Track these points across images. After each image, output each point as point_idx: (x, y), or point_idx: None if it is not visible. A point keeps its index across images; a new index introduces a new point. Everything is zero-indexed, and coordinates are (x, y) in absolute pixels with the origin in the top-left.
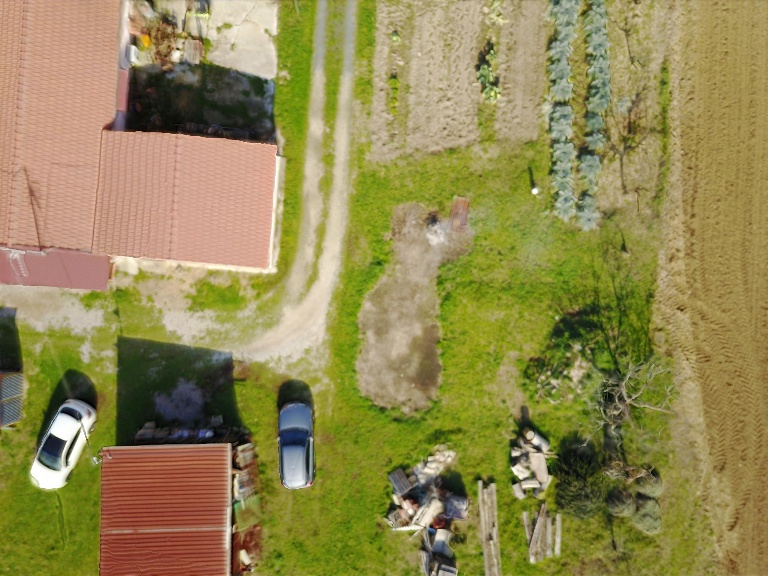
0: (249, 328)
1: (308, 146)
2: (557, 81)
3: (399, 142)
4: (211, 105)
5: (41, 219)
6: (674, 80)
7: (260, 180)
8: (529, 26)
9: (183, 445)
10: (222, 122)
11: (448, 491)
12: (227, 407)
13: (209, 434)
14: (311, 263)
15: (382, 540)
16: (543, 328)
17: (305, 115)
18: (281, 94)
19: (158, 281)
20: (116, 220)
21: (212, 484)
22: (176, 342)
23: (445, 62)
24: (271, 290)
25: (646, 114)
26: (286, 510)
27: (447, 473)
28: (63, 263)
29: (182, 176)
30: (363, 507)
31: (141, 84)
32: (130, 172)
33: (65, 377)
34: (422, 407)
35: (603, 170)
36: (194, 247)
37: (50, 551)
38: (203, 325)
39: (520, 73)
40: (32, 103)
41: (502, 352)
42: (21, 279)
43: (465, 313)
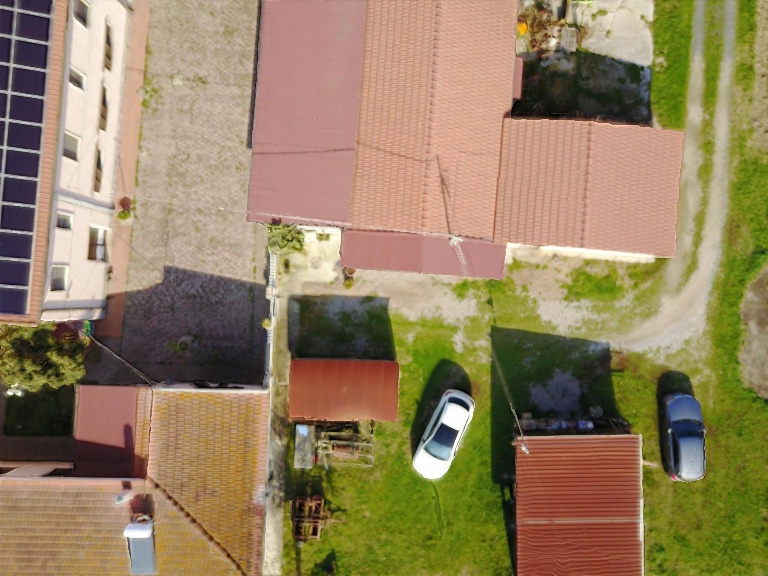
0: (626, 319)
1: (687, 134)
2: None
3: None
4: (586, 93)
5: (450, 208)
6: None
7: (667, 168)
8: None
9: (594, 436)
10: (598, 110)
11: None
12: (604, 398)
13: (592, 425)
14: (690, 253)
15: None
16: None
17: (684, 102)
18: (658, 81)
19: (533, 271)
20: (521, 209)
21: (624, 476)
22: (551, 332)
23: None
24: (649, 280)
25: None
26: (666, 503)
27: None
28: (468, 252)
29: (594, 164)
30: (748, 501)
31: None
32: (537, 160)
33: (438, 367)
34: None
35: None
36: (604, 236)
37: (428, 541)
38: (579, 315)
39: None
40: (444, 91)
41: None
42: (432, 268)
43: None
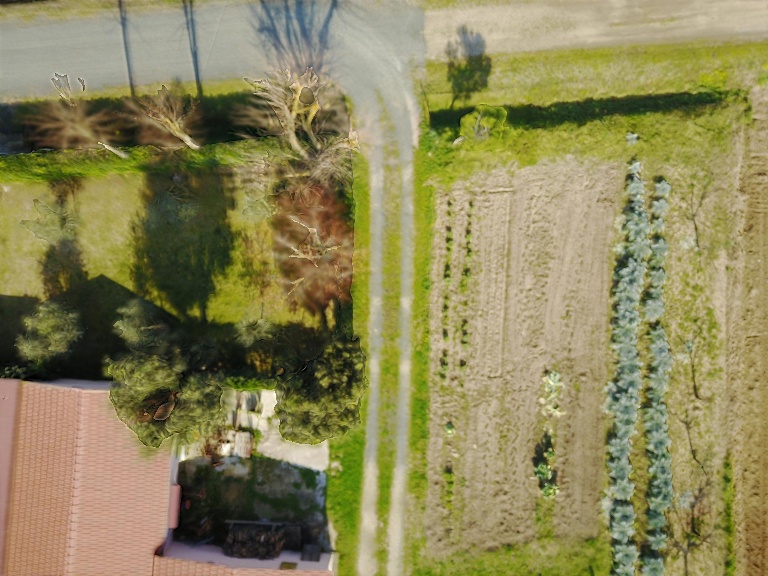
0: None
1: (362, 541)
2: (618, 481)
3: (455, 537)
4: (262, 498)
5: None
6: (737, 472)
7: None
8: (587, 418)
9: None
10: (273, 516)
11: None
12: None
13: None
14: None
15: None
16: None
17: (358, 509)
18: (334, 486)
19: None
20: None
21: None
22: None
23: (501, 454)
24: None
25: (710, 510)
26: None
27: None
28: None
29: None
30: None
31: (191, 478)
32: None
33: None
34: None
35: (667, 569)
36: None
37: None
38: None
39: (579, 466)
40: (84, 539)
41: None
42: None
43: None
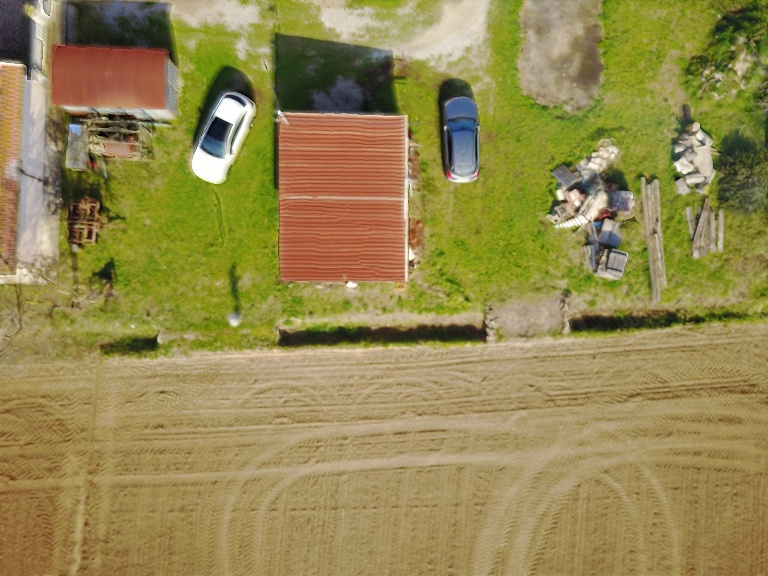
0: (410, 26)
1: None
2: None
3: None
4: None
5: None
6: None
7: None
8: None
9: (360, 116)
10: None
11: (614, 183)
12: (387, 106)
13: None
14: None
15: (544, 238)
16: (706, 26)
17: None
18: None
19: None
20: None
21: (389, 155)
22: (335, 40)
23: None
24: None
25: None
26: (447, 209)
27: (609, 171)
28: None
29: None
30: (525, 205)
31: None
32: None
33: (222, 75)
34: (584, 106)
35: None
36: None
37: (209, 248)
38: (363, 23)
39: None
40: None
41: (664, 50)
42: None
43: (628, 11)
